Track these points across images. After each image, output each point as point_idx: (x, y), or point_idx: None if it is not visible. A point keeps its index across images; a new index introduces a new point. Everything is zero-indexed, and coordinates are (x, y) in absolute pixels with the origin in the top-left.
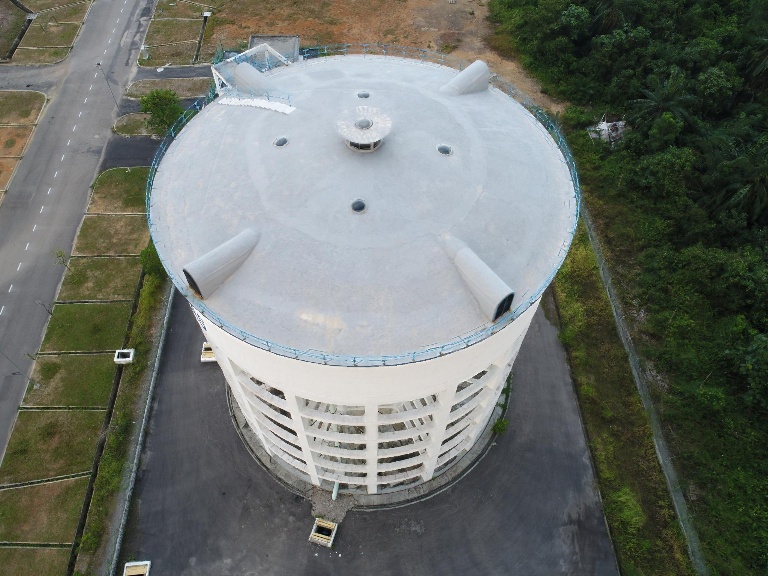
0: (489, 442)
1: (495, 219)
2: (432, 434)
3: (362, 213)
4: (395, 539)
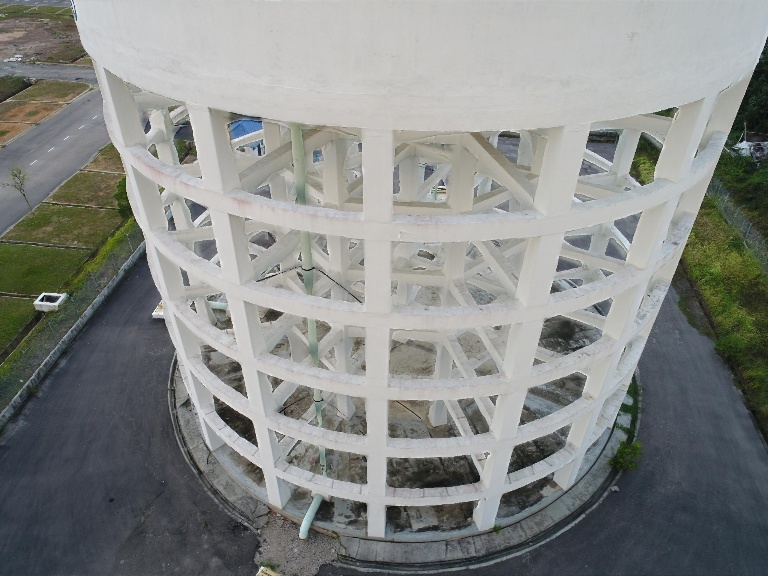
0: (604, 485)
1: None
2: (508, 358)
3: None
4: None
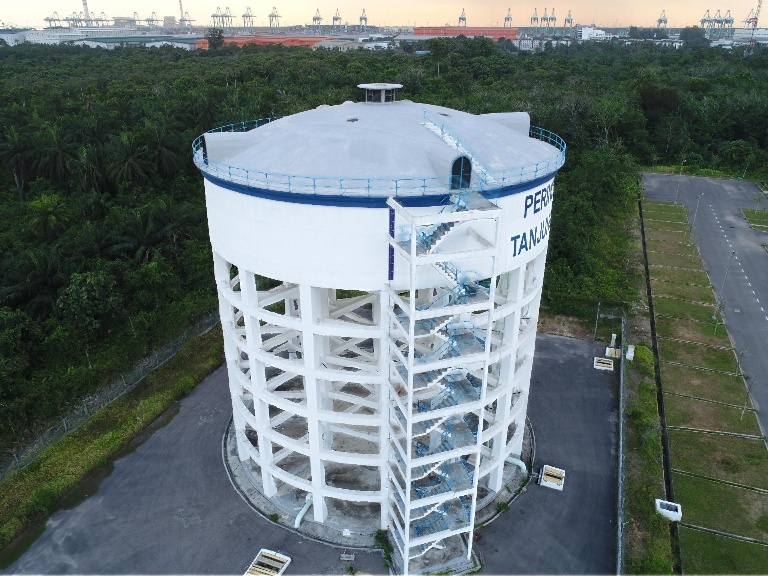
0: None
1: None
2: None
3: None
4: None
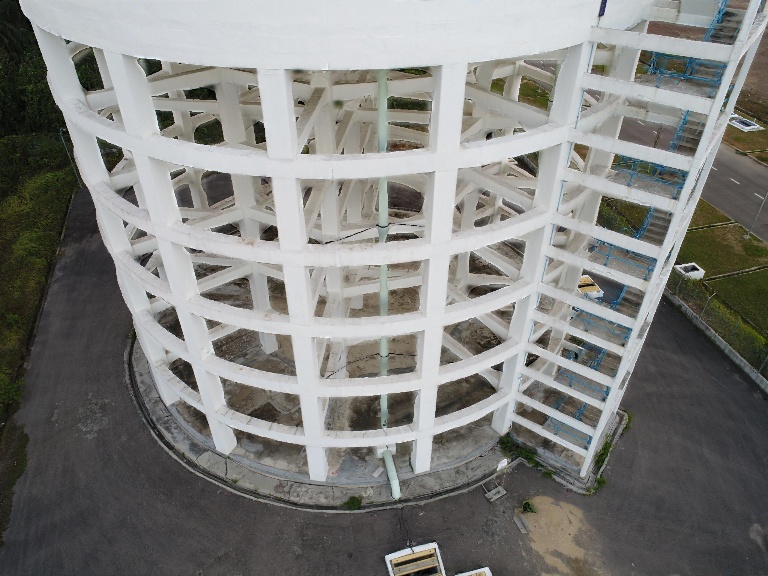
0: None
1: None
2: None
3: None
4: None
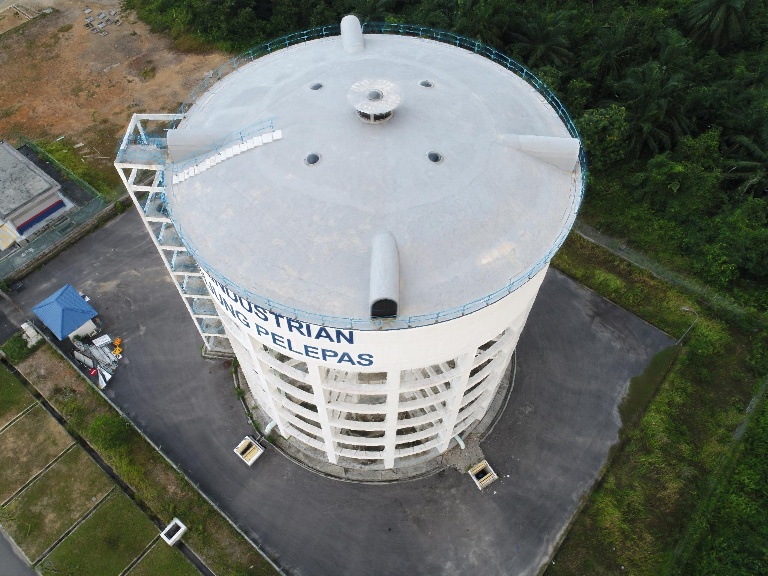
0: None
1: (505, 108)
2: None
3: (442, 160)
4: (525, 429)
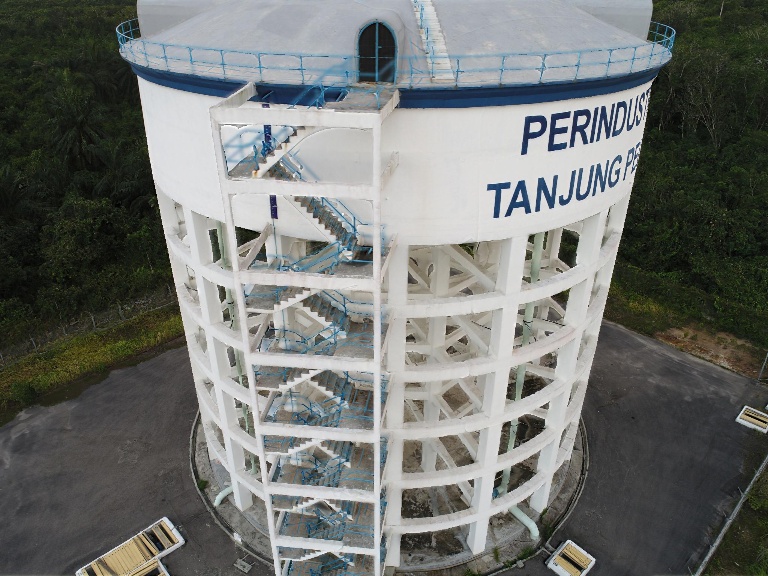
0: None
1: None
2: None
3: None
4: None
